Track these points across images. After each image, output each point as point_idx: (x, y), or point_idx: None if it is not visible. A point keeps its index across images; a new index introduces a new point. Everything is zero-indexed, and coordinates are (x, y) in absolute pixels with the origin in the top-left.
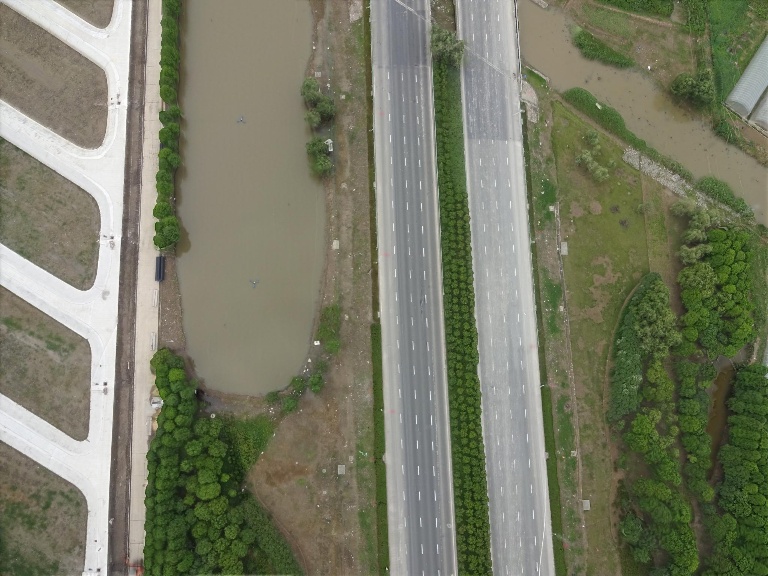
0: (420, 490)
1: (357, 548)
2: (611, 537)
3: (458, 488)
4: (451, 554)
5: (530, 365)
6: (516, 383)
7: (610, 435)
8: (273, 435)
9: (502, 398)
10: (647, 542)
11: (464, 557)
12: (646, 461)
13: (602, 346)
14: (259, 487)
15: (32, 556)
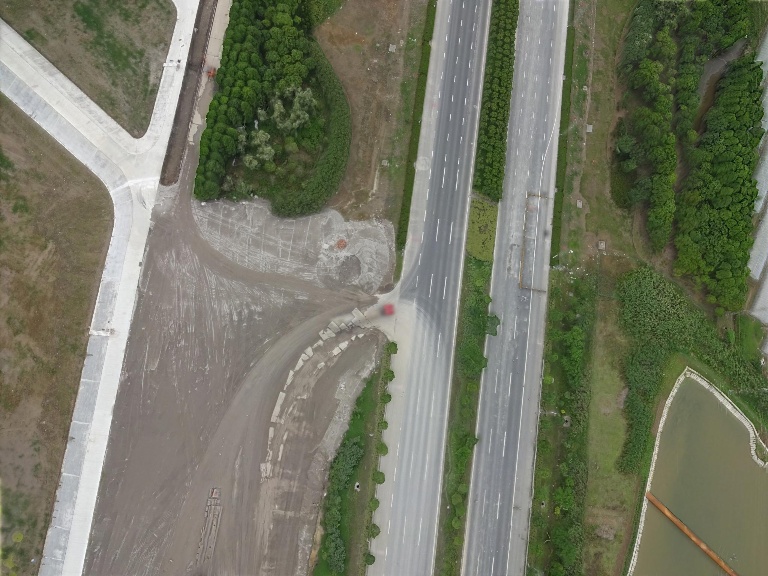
0: (456, 75)
1: (395, 109)
2: (606, 157)
3: (489, 75)
4: (474, 128)
5: (561, 10)
6: (548, 19)
7: (617, 82)
8: (340, 7)
9: (534, 27)
10: (637, 153)
11: (486, 124)
12: (646, 94)
13: (621, 17)
14: (322, 42)
15: (124, 40)
